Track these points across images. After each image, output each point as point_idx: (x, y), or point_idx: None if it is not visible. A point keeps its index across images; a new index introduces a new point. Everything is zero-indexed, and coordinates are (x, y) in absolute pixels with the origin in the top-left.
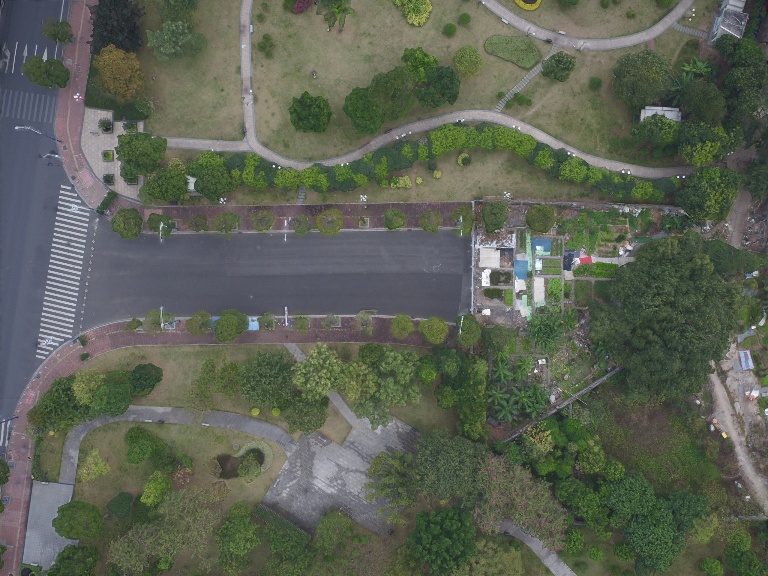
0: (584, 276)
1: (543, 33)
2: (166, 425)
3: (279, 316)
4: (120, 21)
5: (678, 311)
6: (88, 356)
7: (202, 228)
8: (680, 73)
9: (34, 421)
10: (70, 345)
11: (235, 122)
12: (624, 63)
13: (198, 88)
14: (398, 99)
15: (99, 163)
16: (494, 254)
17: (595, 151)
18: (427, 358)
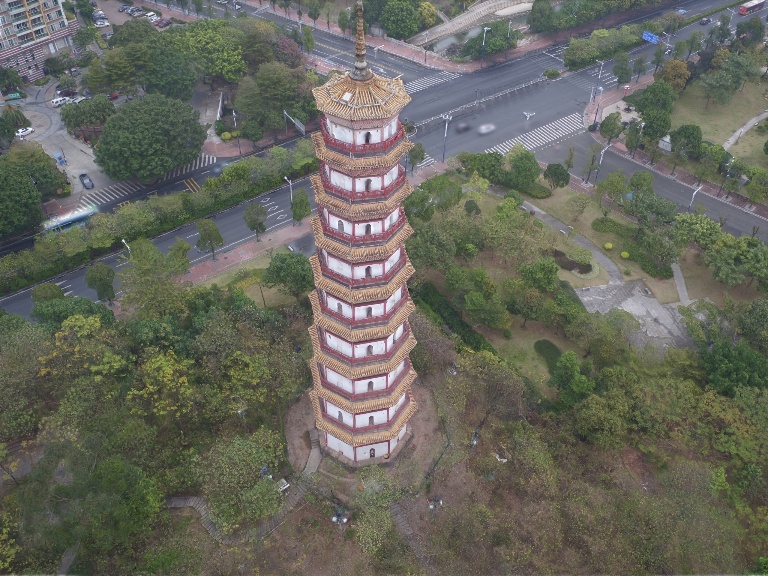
0: None
1: None
2: (533, 217)
3: None
4: (687, 70)
5: None
6: None
7: (656, 156)
8: None
9: (462, 155)
10: None
11: (714, 144)
12: None
13: (701, 123)
14: None
15: None
16: None
17: None
18: None
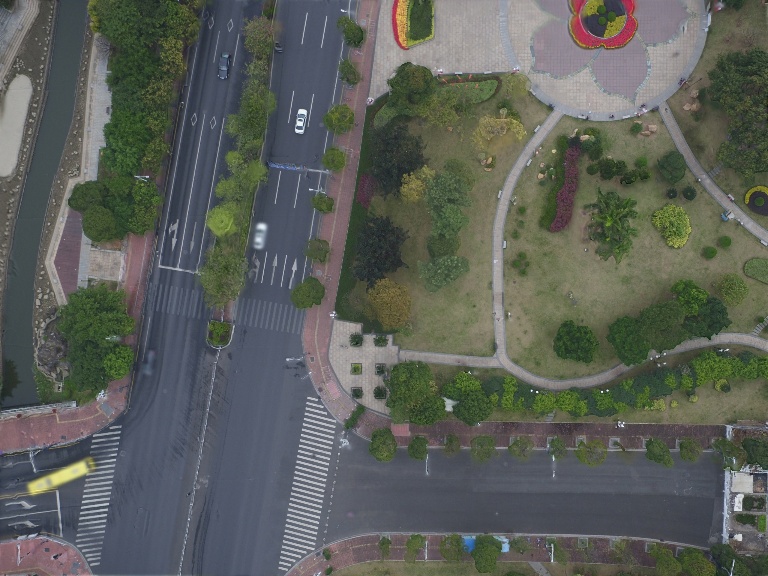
0: None
1: None
2: None
3: (525, 534)
4: (388, 248)
5: None
6: (332, 570)
7: None
8: None
9: None
10: (314, 558)
11: (486, 338)
12: None
13: (450, 304)
14: (668, 333)
15: (347, 376)
16: (747, 479)
17: None
18: None
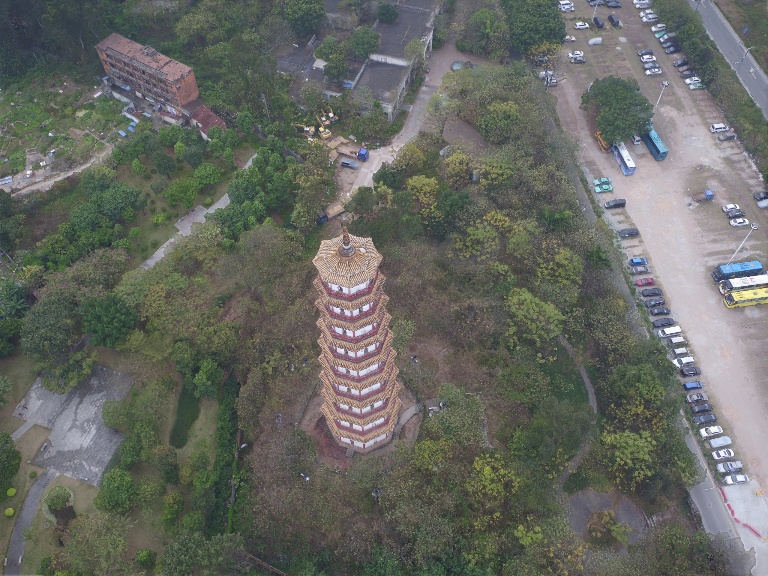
0: None
1: None
2: None
3: None
4: None
5: None
6: None
7: None
8: None
9: None
10: None
11: None
12: None
13: None
14: None
15: None
16: None
17: None
18: None
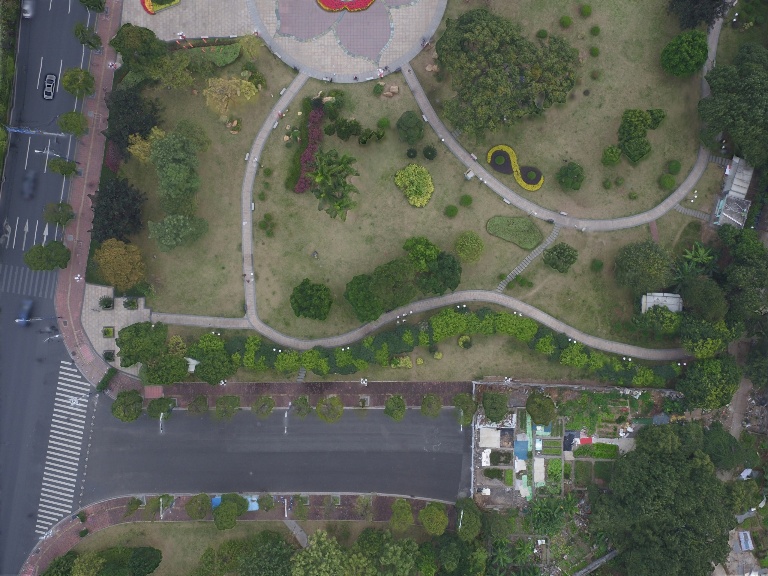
0: (584, 457)
1: (545, 213)
2: None
3: (279, 493)
4: (121, 210)
5: (678, 516)
6: (87, 532)
7: (202, 409)
8: (682, 260)
9: None
10: (69, 521)
11: (236, 300)
12: (626, 256)
13: (199, 266)
14: (399, 290)
15: (99, 339)
16: (494, 434)
17: (596, 332)
18: (426, 546)
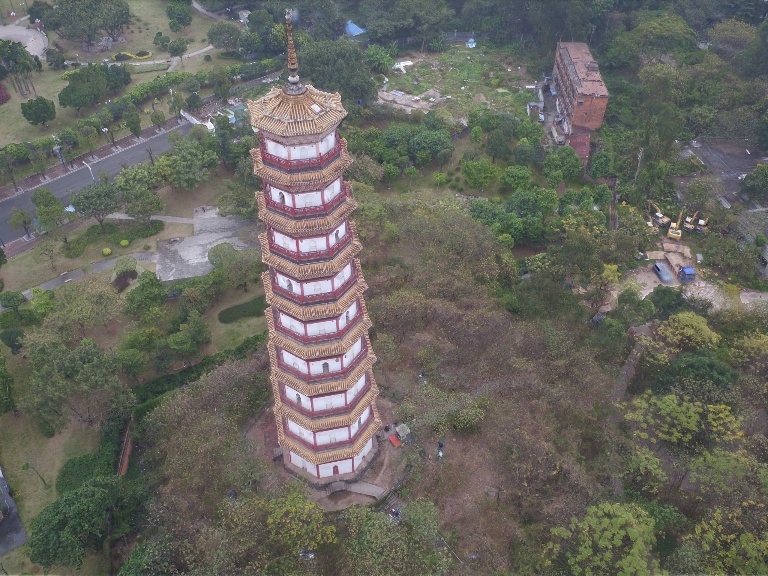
0: None
1: (163, 60)
2: None
3: None
4: None
5: None
6: None
7: None
8: None
9: None
10: None
11: None
12: (209, 31)
13: None
14: None
15: None
16: None
17: None
18: None
